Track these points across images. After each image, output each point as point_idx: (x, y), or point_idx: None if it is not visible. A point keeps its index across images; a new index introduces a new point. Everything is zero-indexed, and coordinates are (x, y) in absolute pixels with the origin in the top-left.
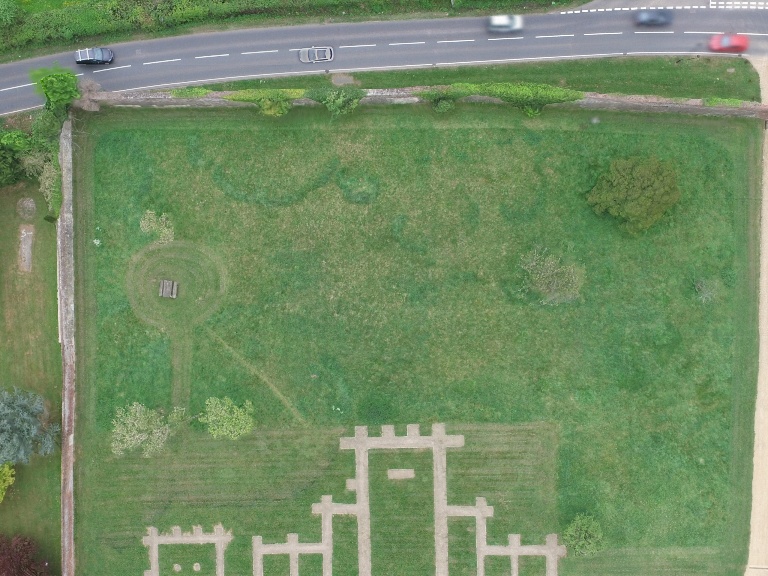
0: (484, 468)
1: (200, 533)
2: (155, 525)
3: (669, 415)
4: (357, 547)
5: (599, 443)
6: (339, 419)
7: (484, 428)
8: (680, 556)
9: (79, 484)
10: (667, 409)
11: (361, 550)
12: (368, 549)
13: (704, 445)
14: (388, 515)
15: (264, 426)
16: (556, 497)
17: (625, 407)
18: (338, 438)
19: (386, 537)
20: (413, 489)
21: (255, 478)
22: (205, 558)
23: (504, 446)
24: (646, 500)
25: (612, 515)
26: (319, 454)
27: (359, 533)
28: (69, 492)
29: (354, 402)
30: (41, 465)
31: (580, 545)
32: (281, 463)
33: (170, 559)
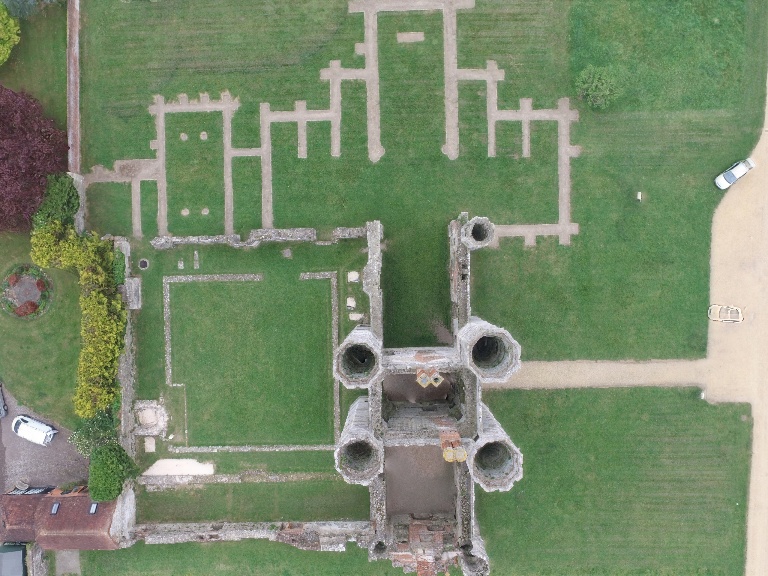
0: (495, 30)
1: (207, 101)
2: (161, 93)
3: None
4: (366, 113)
5: (612, 4)
6: None
7: None
8: (695, 119)
9: (85, 52)
10: None
11: (370, 116)
12: (377, 115)
13: (719, 5)
14: (397, 79)
15: None
16: (568, 60)
17: None
18: (347, 1)
19: (395, 102)
20: (423, 52)
21: (263, 43)
22: (212, 126)
23: (515, 8)
24: (660, 61)
25: (625, 77)
26: (327, 18)
27: (368, 99)
28: (75, 55)
29: None
30: (46, 37)
31: (593, 88)
32: (289, 28)
33: (177, 128)
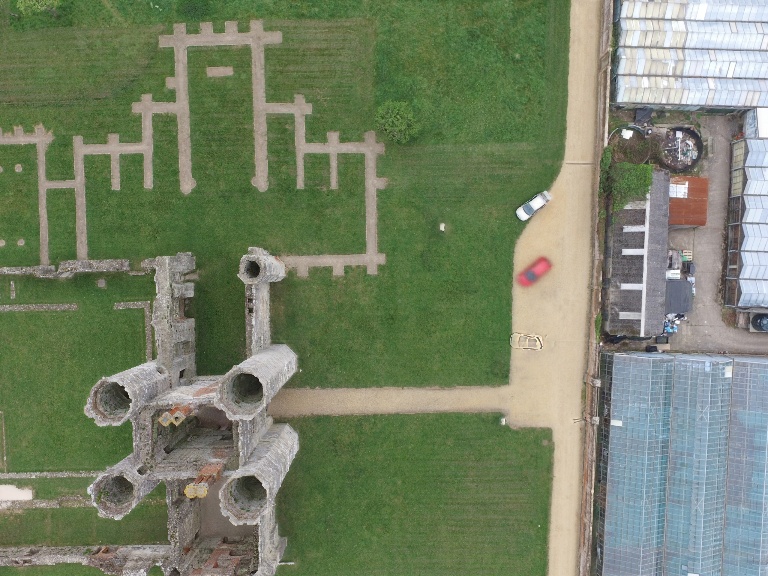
0: (302, 65)
1: (21, 134)
2: None
3: (485, 11)
4: (177, 146)
5: (416, 39)
6: (158, 17)
7: (302, 24)
8: (497, 152)
9: None
10: (483, 5)
11: (181, 149)
12: (188, 148)
13: (520, 40)
14: (207, 113)
15: (84, 26)
16: (374, 94)
17: (442, 3)
18: (157, 36)
19: (206, 135)
20: (232, 86)
21: (75, 77)
22: (26, 159)
23: (322, 43)
24: (463, 96)
25: (429, 111)
26: (138, 53)
27: (179, 132)
28: None
29: (173, 1)
30: None
31: (390, 124)
32: (101, 62)
33: None
